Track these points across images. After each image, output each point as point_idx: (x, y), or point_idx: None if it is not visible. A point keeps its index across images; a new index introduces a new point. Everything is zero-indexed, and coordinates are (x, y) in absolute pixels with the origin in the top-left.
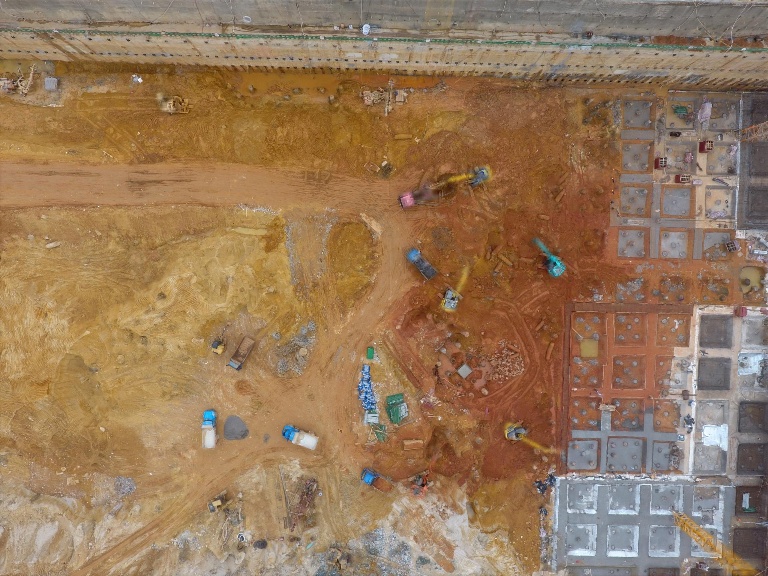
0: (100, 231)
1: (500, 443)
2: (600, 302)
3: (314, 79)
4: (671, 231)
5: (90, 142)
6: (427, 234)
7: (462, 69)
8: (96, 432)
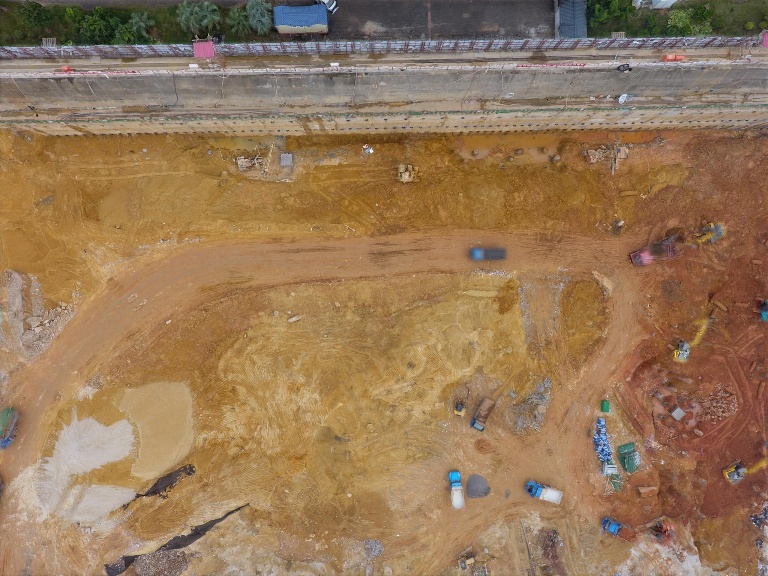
0: (339, 302)
1: (718, 482)
2: None
3: (534, 139)
4: None
5: (328, 216)
6: (656, 288)
7: (688, 125)
8: (344, 498)
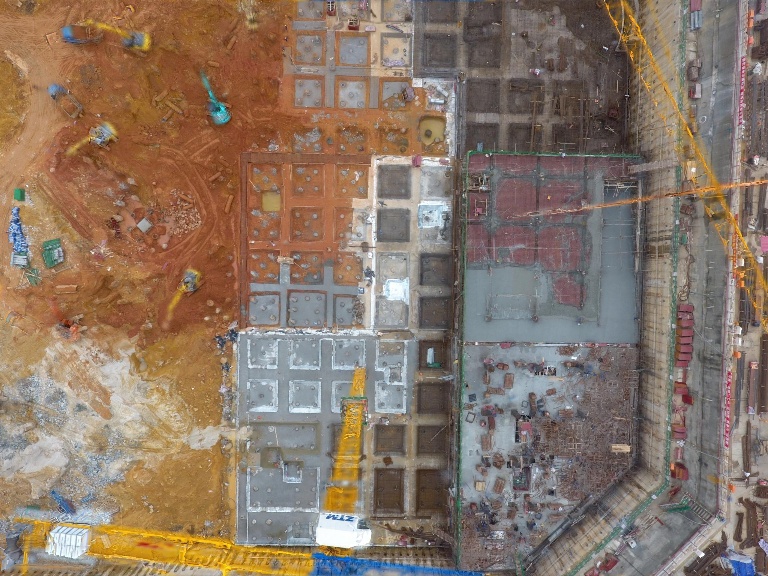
0: None
1: (175, 296)
2: (276, 152)
3: None
4: (349, 80)
5: None
6: (75, 72)
7: None
8: None
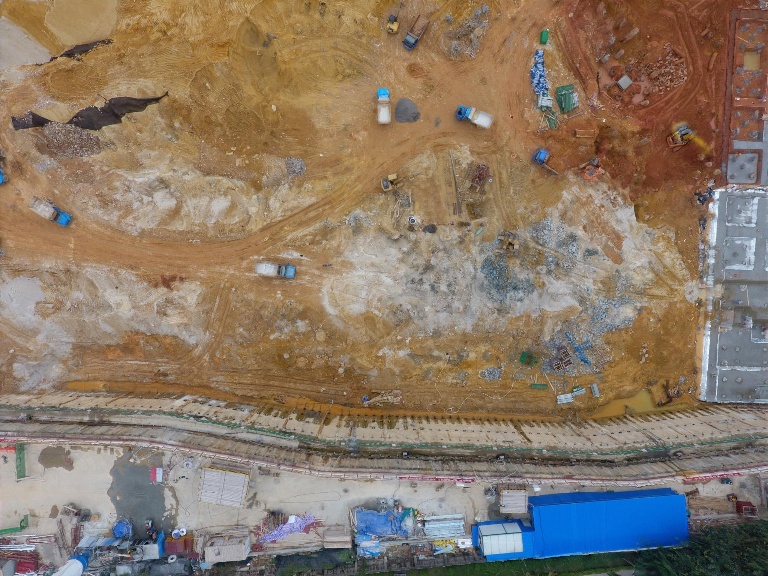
0: None
1: (662, 151)
2: (766, 9)
3: None
4: None
5: None
6: None
7: None
8: (268, 110)
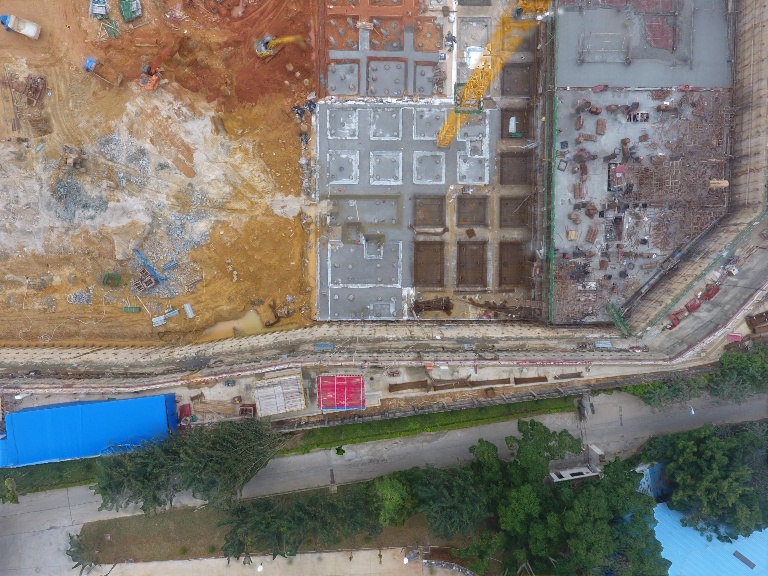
0: None
1: (253, 63)
2: None
3: None
4: None
5: None
6: None
7: None
8: None
